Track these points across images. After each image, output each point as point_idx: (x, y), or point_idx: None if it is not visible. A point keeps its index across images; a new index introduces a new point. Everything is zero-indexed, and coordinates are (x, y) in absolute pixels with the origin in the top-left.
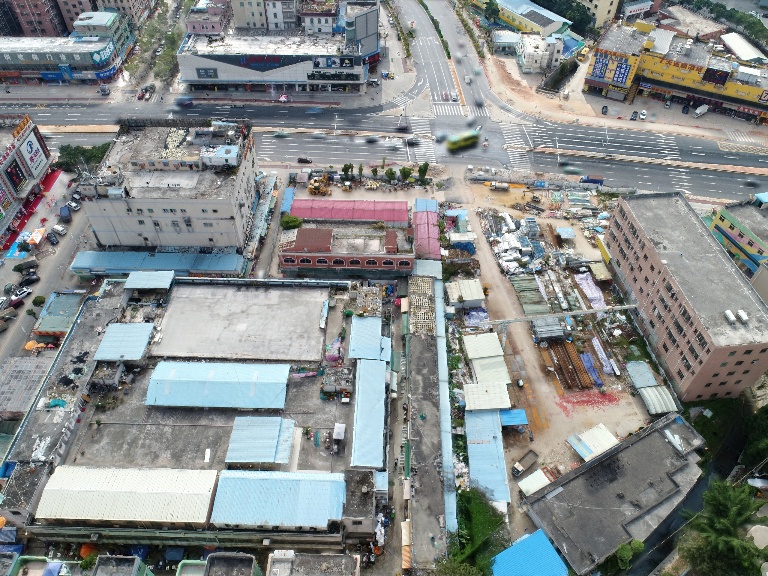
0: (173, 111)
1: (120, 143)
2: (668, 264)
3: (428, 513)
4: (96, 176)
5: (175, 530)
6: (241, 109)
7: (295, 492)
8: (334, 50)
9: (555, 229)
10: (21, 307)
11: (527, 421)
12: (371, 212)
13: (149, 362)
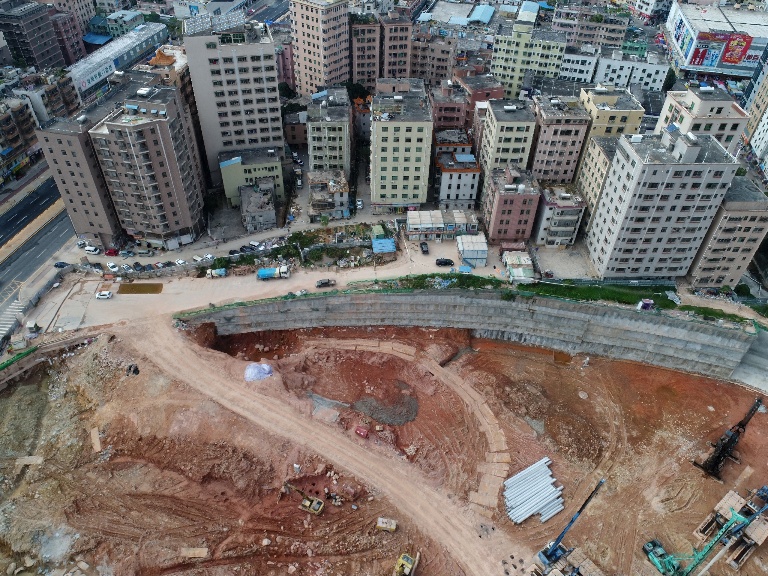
0: None
1: None
2: None
3: None
4: None
5: None
6: None
7: (529, 5)
8: None
9: None
10: None
11: None
12: None
13: None
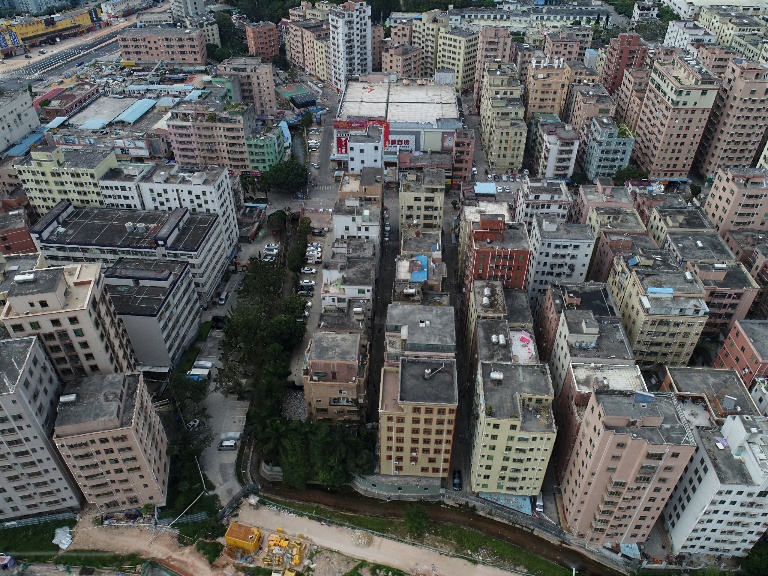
0: None
1: None
2: None
3: None
4: None
5: None
6: None
7: None
8: None
9: None
10: None
11: None
12: (53, 95)
13: None
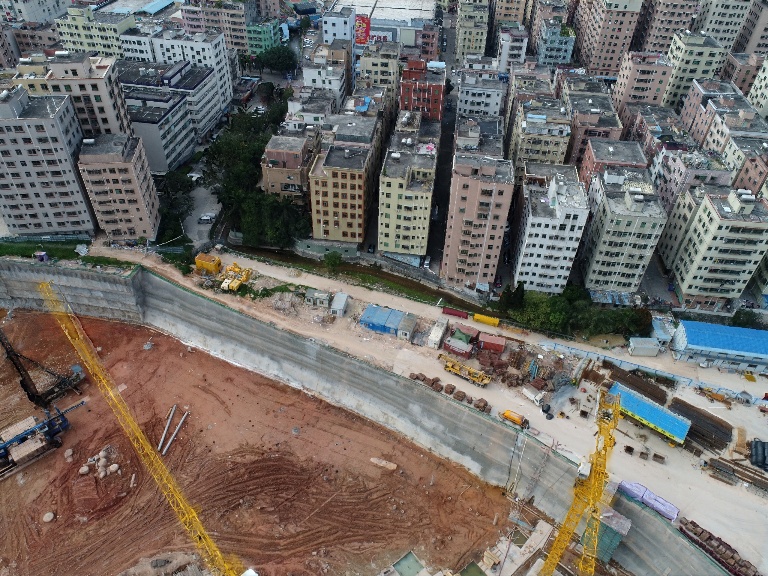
0: None
1: None
2: None
3: None
4: (7, 0)
5: None
6: None
7: None
8: None
9: None
10: None
11: None
12: None
13: None
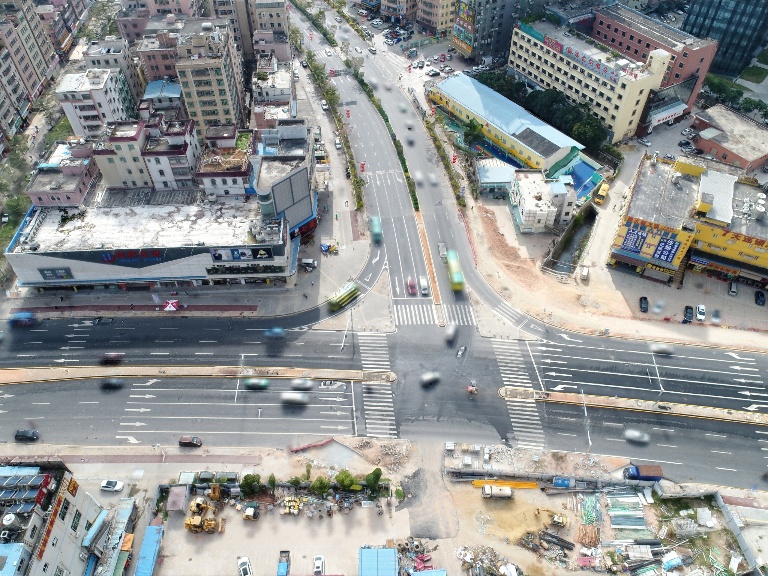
0: (4, 337)
1: None
2: None
3: None
4: None
5: None
6: (108, 327)
7: None
8: (244, 231)
9: None
10: None
11: None
12: None
13: None
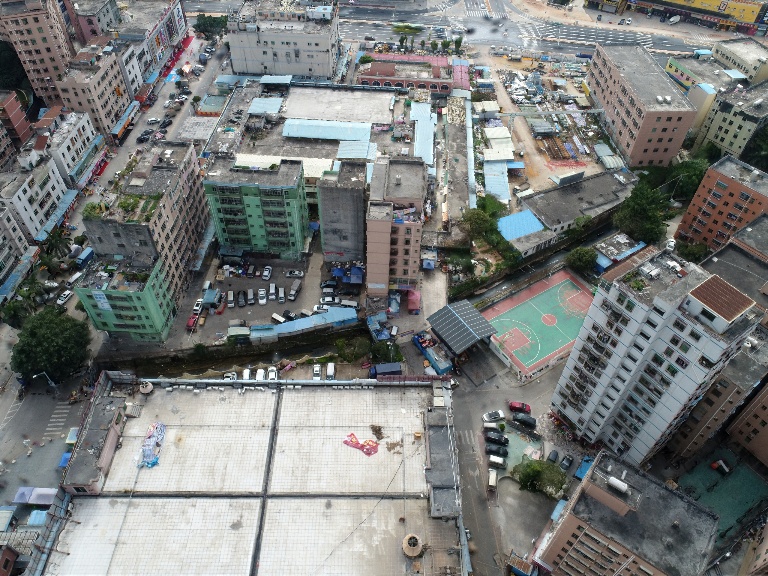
0: None
1: (247, 6)
2: (624, 76)
3: (459, 199)
4: None
5: (309, 184)
6: None
7: None
8: None
9: (553, 82)
10: (182, 106)
11: (524, 167)
12: None
13: (280, 120)
